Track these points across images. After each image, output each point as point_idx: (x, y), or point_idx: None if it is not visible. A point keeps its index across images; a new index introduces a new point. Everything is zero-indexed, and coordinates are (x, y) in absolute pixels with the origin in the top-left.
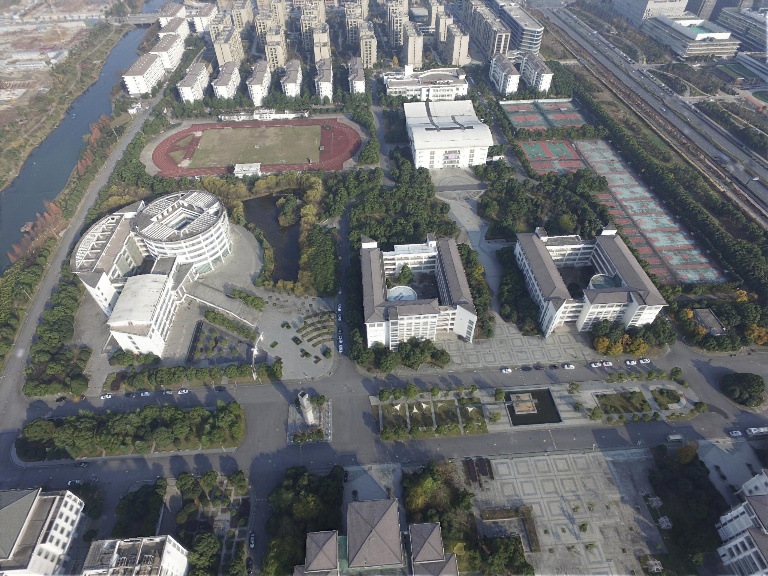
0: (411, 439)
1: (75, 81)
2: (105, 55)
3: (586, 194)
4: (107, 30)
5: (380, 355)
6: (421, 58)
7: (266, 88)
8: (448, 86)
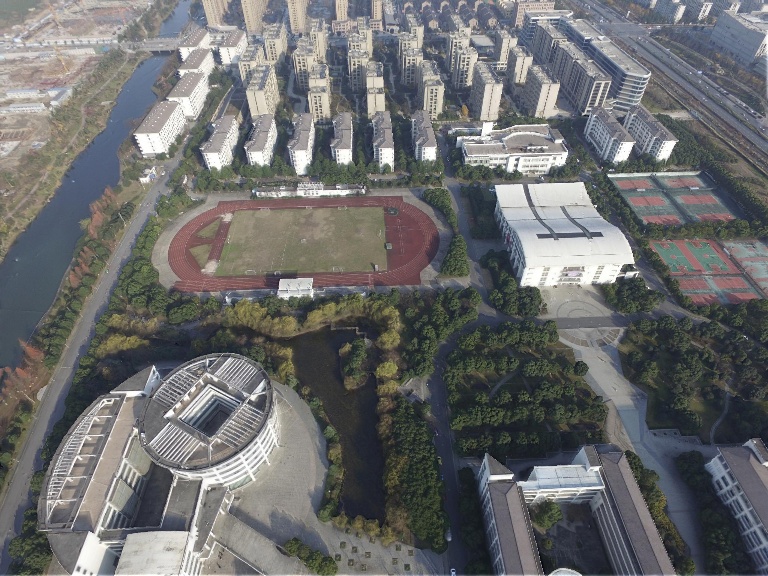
0: None
1: (78, 131)
2: (115, 93)
3: None
4: (119, 59)
5: None
6: (498, 109)
7: (310, 150)
8: (543, 155)
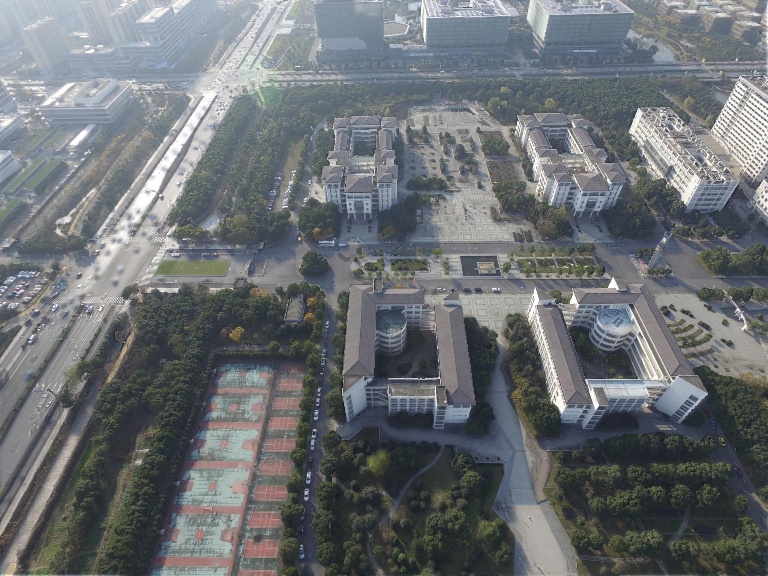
0: None
1: None
2: None
3: (294, 568)
4: None
5: None
6: None
7: None
8: None
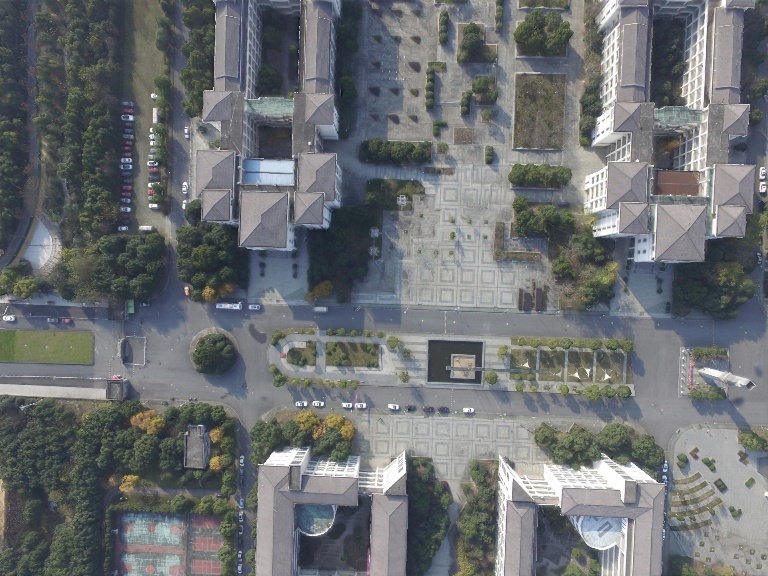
0: None
1: None
2: None
3: None
4: None
5: (618, 450)
6: None
7: None
8: None
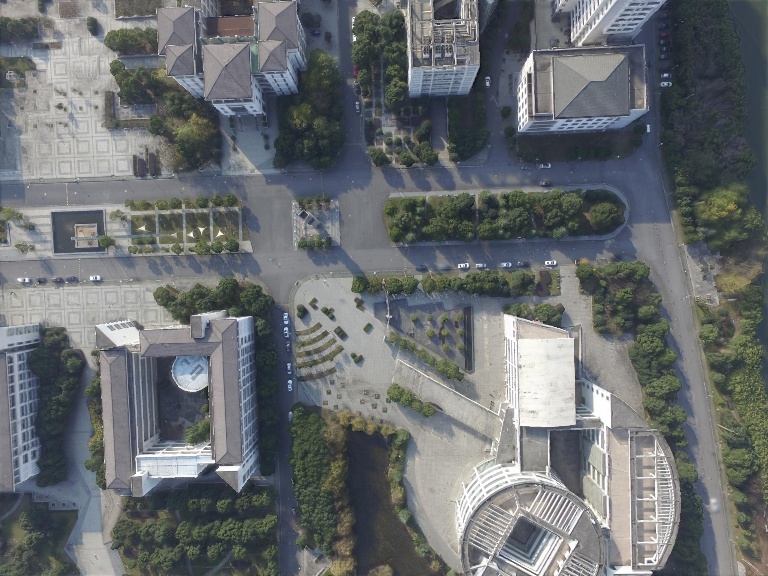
0: None
1: None
2: None
3: None
4: None
5: None
6: None
7: None
8: None
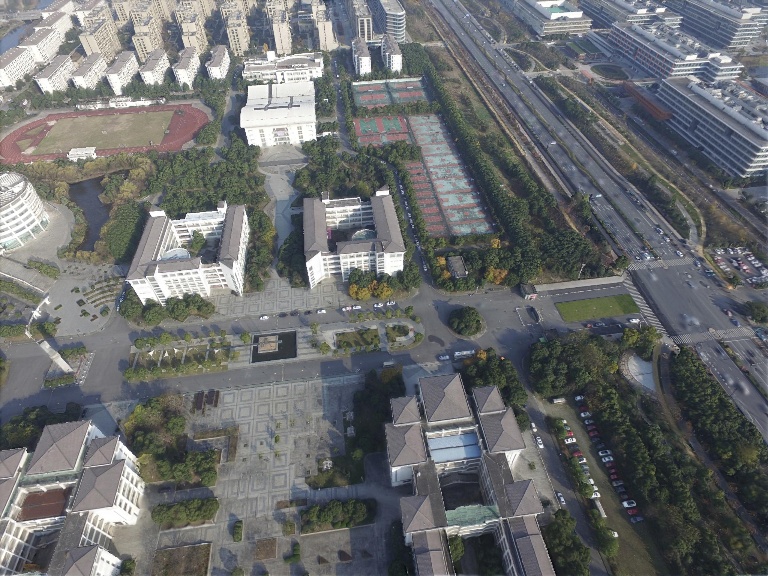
0: (156, 379)
1: None
2: None
3: (396, 163)
4: None
5: None
6: (289, 44)
7: (129, 77)
8: (301, 69)
